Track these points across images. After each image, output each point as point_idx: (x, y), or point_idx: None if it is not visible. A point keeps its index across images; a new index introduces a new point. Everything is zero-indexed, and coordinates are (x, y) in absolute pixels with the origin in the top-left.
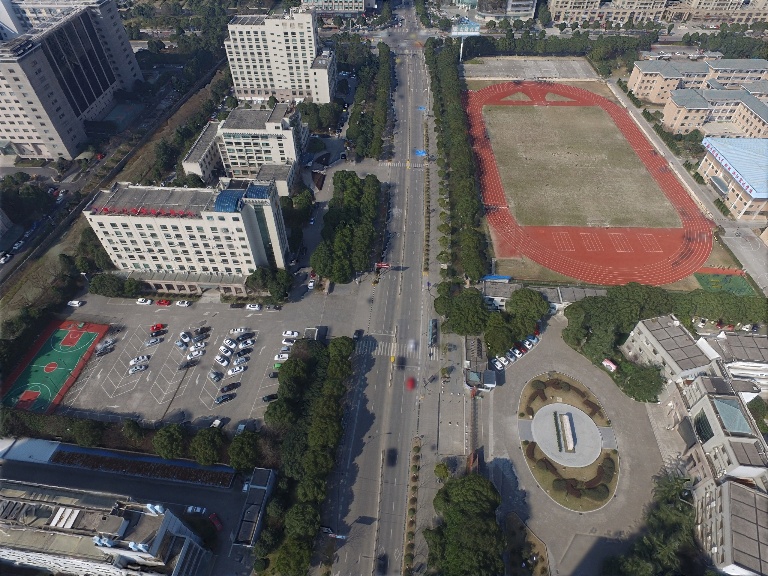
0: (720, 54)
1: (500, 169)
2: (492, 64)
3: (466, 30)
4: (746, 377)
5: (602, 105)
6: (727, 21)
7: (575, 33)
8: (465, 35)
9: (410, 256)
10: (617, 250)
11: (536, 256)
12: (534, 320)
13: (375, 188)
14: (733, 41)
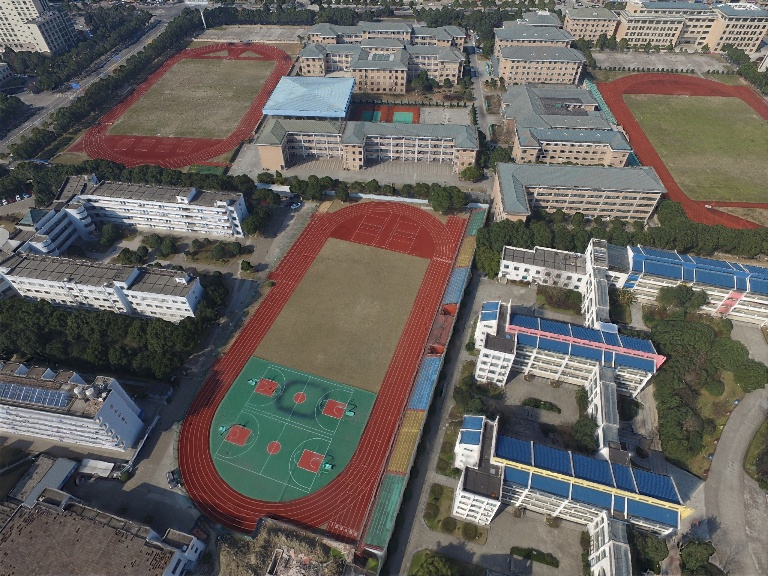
0: (424, 24)
1: (139, 100)
2: (231, 30)
3: (196, 0)
4: (110, 211)
5: (279, 60)
6: (476, 0)
7: (319, 7)
8: (197, 4)
9: (3, 149)
10: (156, 150)
11: (93, 152)
12: (19, 180)
13: (7, 105)
14: (432, 13)
